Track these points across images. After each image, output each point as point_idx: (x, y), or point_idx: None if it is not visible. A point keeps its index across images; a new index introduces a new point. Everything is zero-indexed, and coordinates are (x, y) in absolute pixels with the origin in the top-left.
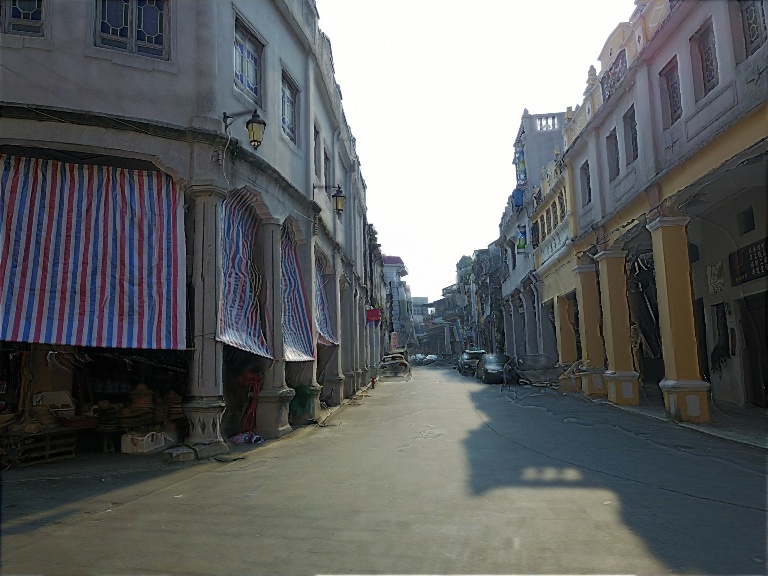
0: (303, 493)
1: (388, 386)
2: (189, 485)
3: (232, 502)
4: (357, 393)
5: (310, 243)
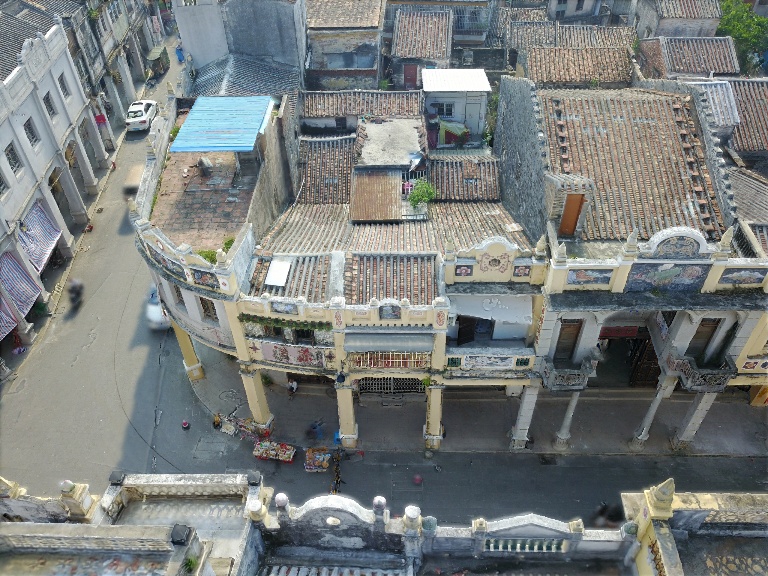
0: (31, 418)
1: (127, 159)
2: (1, 411)
3: (13, 427)
4: (95, 205)
5: (16, 250)
